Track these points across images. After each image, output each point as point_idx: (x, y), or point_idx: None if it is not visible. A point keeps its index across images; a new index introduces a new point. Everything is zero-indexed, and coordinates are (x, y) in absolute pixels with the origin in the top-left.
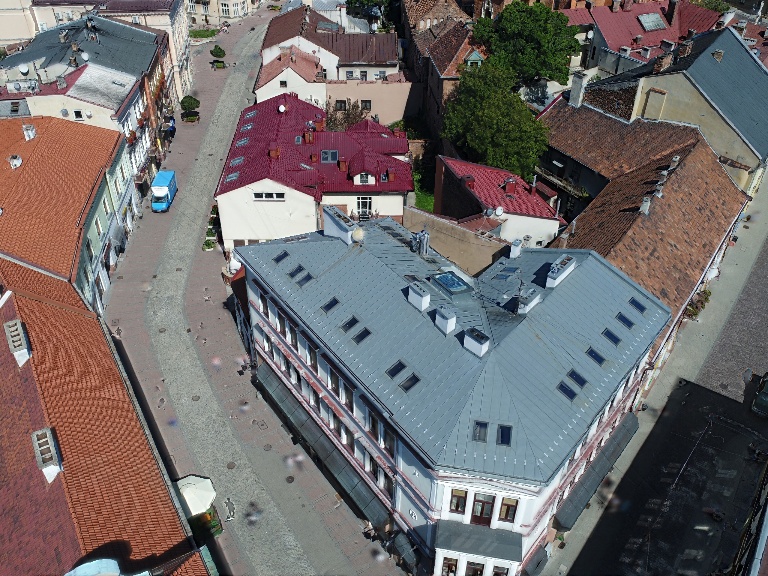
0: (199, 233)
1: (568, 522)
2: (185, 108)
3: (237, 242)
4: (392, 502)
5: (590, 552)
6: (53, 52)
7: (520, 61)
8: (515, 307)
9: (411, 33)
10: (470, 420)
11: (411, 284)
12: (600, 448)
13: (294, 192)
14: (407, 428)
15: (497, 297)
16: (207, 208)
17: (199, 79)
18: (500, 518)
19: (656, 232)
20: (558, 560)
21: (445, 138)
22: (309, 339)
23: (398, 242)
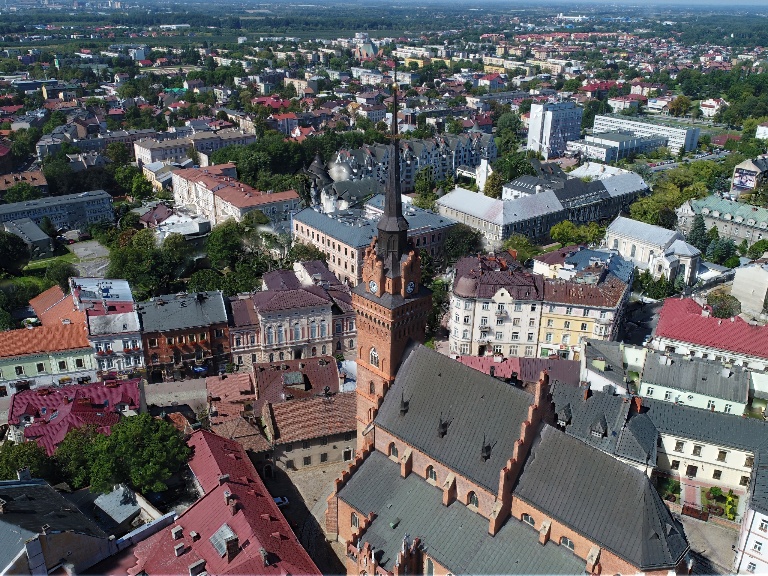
0: None
1: None
2: None
3: None
4: None
5: None
6: None
7: None
8: None
9: None
10: None
11: None
12: None
13: None
14: None
15: None
16: None
17: None
18: None
19: None
20: None
21: None
22: None
23: None
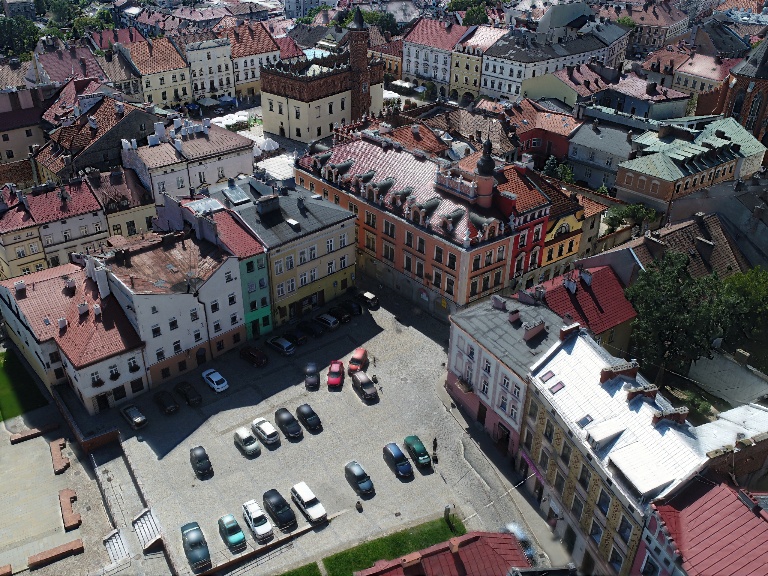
0: None
1: None
2: None
3: None
4: None
5: None
6: None
7: None
8: None
9: None
10: None
11: None
12: None
13: None
14: None
15: None
16: None
17: None
18: None
19: None
20: None
21: None
22: None
23: None
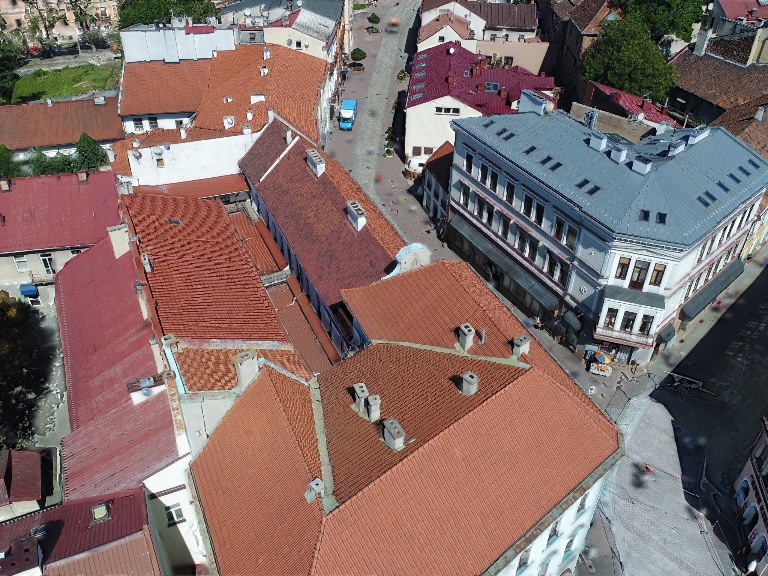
0: (379, 146)
1: (691, 314)
2: (355, 58)
3: (415, 149)
4: (565, 288)
5: (703, 346)
6: (269, 1)
7: (653, 19)
8: (665, 155)
9: (550, 3)
10: (638, 209)
11: (594, 132)
12: (716, 273)
13: (468, 108)
14: (593, 214)
15: (650, 152)
16: (382, 130)
17: (358, 40)
18: (651, 283)
19: (767, 134)
20: (679, 349)
21: (584, 81)
22: (511, 176)
23: (573, 120)
